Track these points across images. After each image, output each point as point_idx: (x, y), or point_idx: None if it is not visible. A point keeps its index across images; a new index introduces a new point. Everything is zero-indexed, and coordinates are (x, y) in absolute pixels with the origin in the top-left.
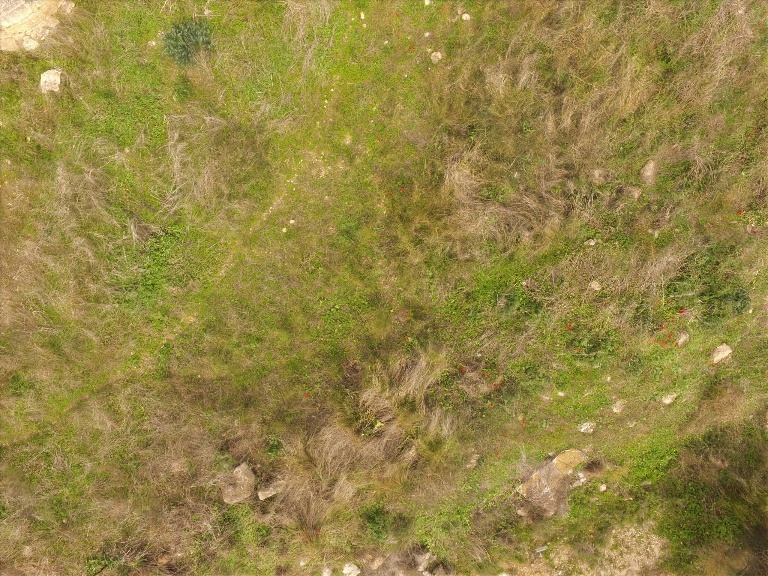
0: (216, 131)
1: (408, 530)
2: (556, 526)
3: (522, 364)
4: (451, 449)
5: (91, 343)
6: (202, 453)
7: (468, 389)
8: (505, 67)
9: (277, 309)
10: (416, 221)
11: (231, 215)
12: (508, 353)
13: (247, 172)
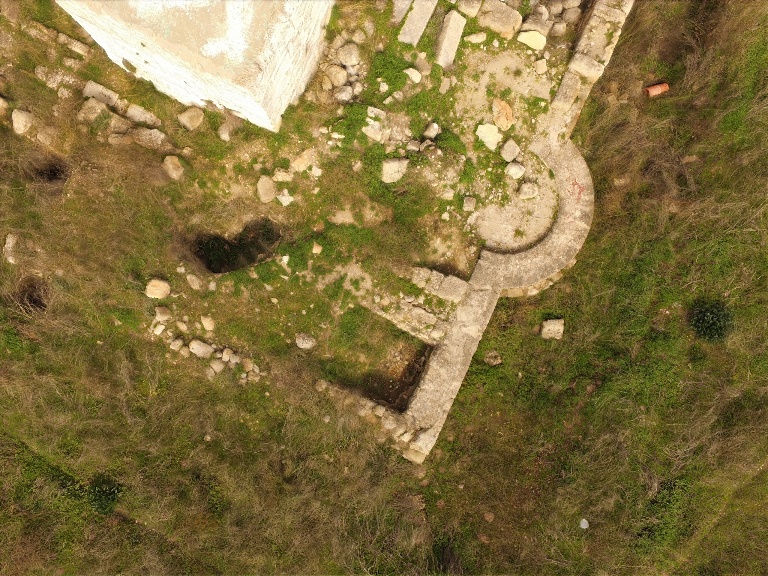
0: (729, 400)
1: None
2: None
3: None
4: None
5: None
6: None
7: None
8: None
9: (763, 556)
10: None
11: (735, 474)
12: None
13: None
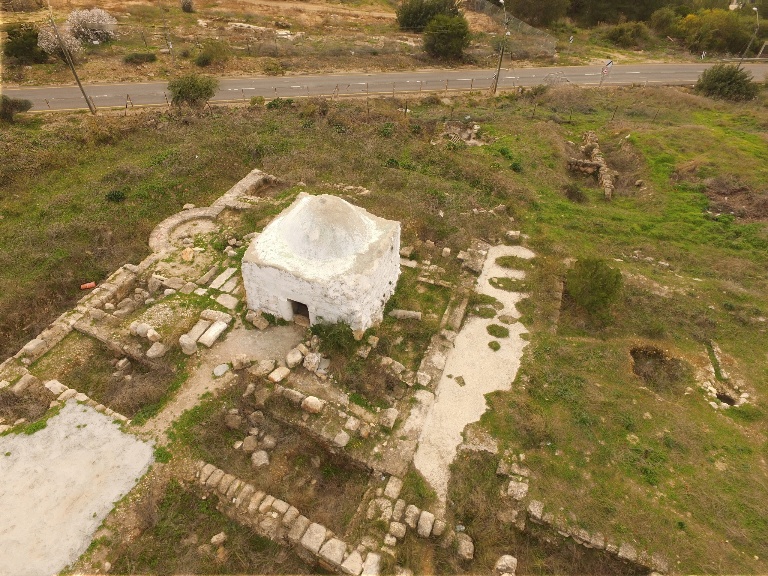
0: None
1: None
2: None
3: None
4: None
5: None
6: None
7: None
8: None
9: None
10: None
11: None
12: None
13: None
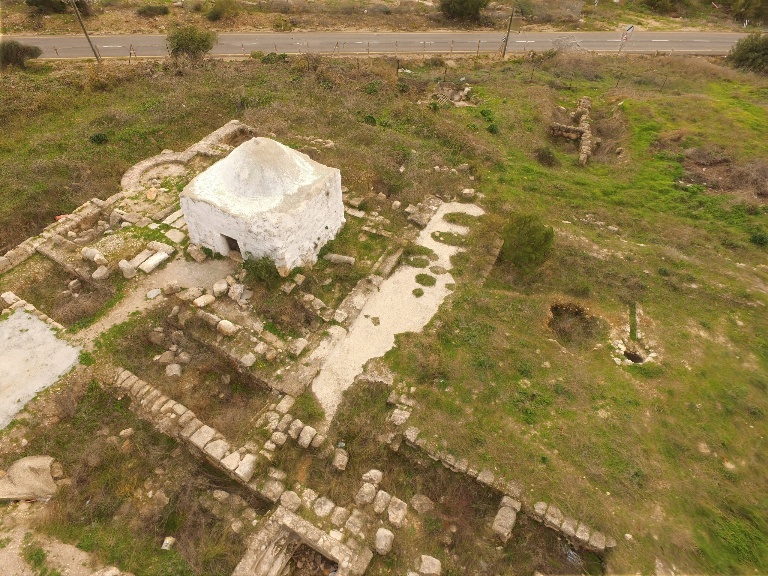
0: None
1: None
2: None
3: None
4: None
5: None
6: None
7: None
8: None
9: None
10: None
11: None
12: None
13: None
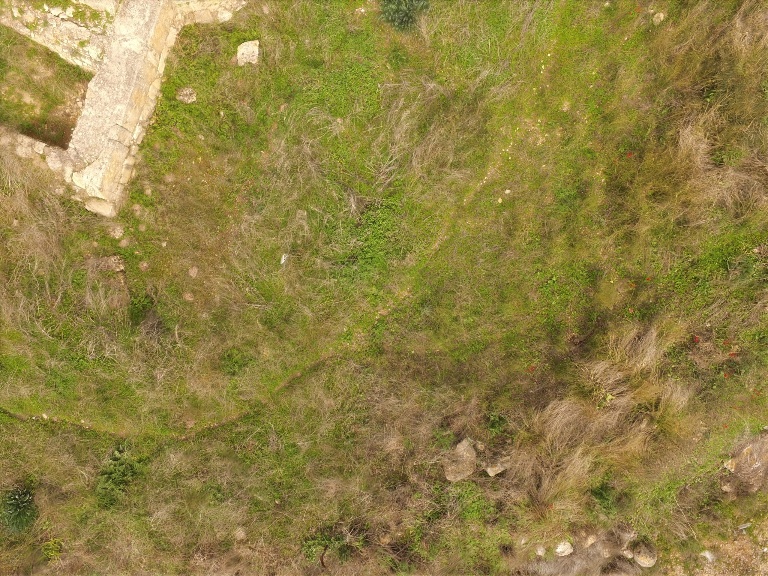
0: (434, 99)
1: (632, 506)
2: (760, 502)
3: (755, 333)
4: (682, 422)
5: (305, 319)
6: (420, 430)
7: (700, 360)
8: (740, 26)
9: (493, 282)
10: (646, 187)
11: (448, 185)
12: (739, 322)
13: (467, 141)
